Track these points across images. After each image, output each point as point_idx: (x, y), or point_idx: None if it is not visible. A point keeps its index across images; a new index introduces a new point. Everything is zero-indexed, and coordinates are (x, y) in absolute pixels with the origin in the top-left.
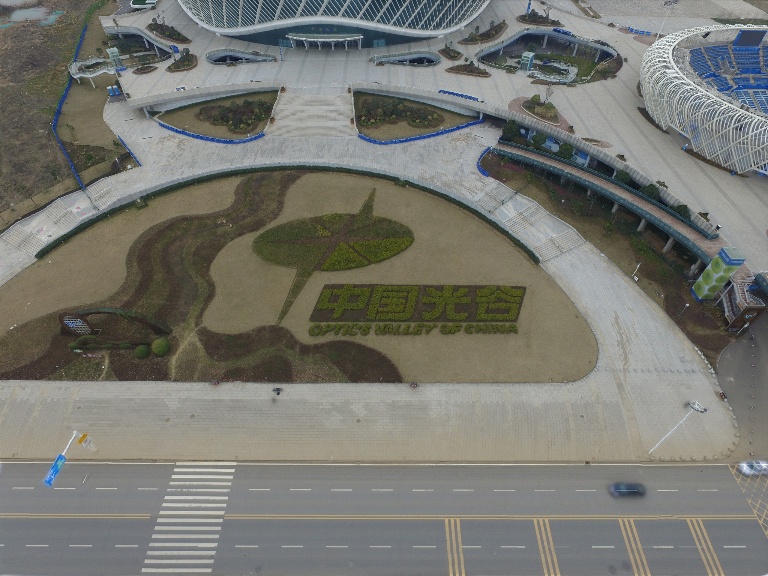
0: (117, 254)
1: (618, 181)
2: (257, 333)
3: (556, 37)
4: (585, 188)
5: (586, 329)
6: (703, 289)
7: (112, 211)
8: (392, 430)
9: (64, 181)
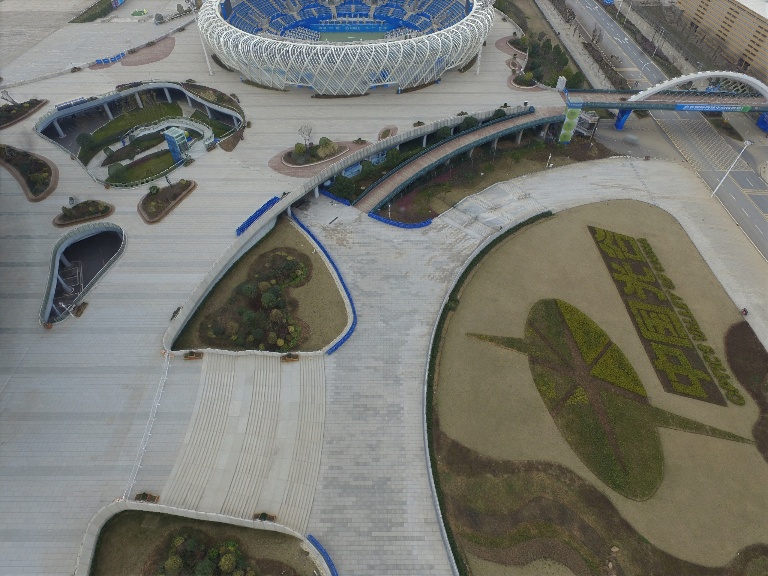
0: None
1: (455, 135)
2: None
3: (70, 114)
4: None
5: (619, 202)
6: (571, 134)
7: None
8: None
9: None
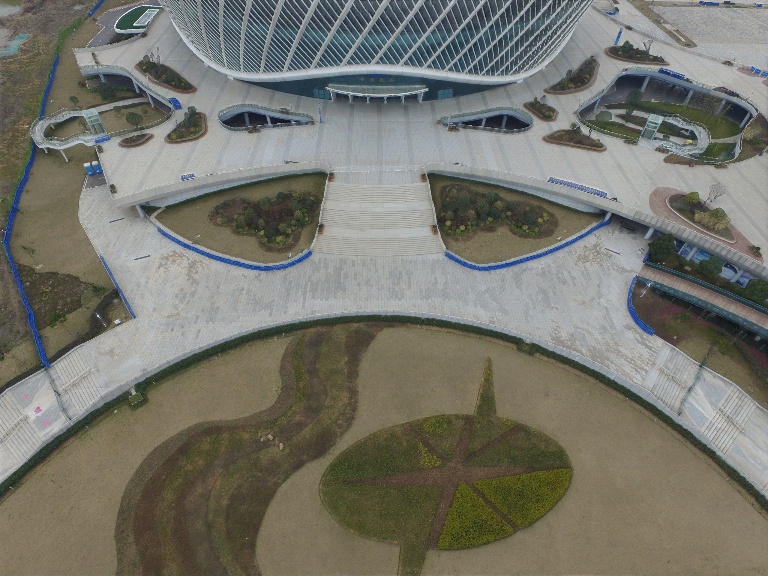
0: (100, 515)
1: None
2: None
3: (662, 80)
4: None
5: None
6: None
7: (91, 417)
8: None
9: (18, 347)
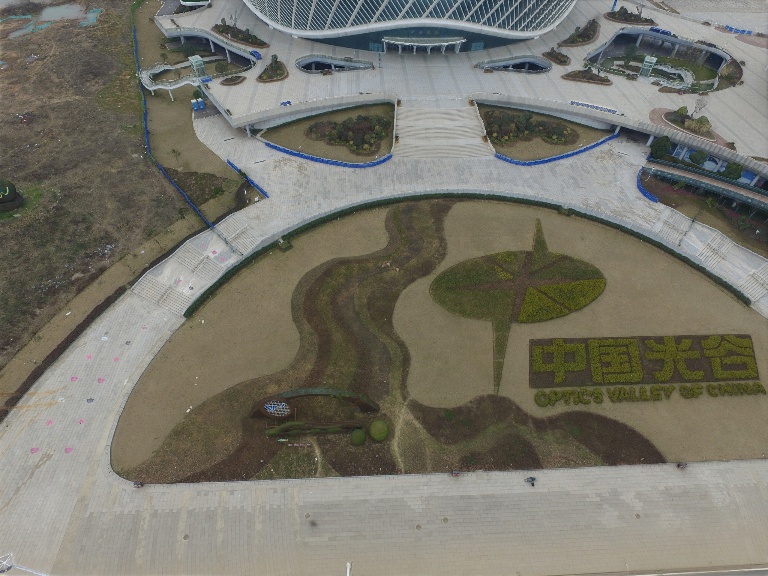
0: (279, 309)
1: None
2: (477, 405)
3: (653, 37)
4: (767, 214)
5: None
6: None
7: (256, 255)
8: (681, 526)
9: None
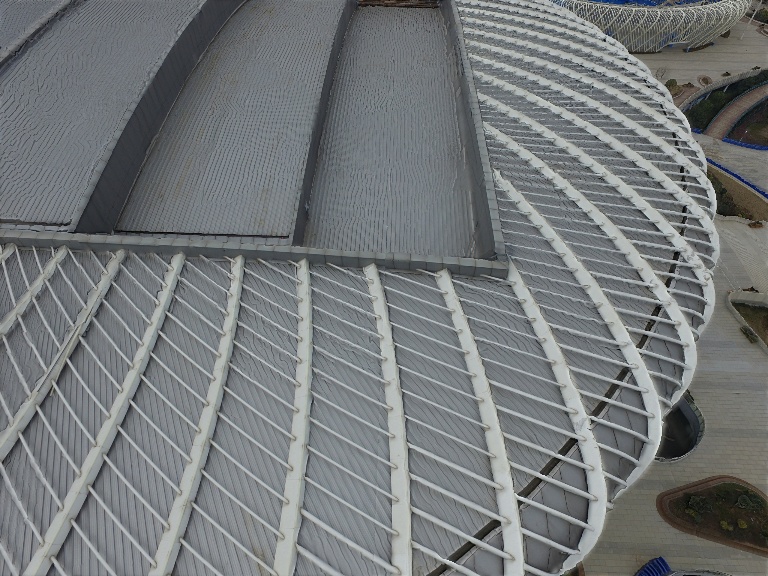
0: None
1: None
2: None
3: None
4: None
5: None
6: None
7: None
8: None
9: None
